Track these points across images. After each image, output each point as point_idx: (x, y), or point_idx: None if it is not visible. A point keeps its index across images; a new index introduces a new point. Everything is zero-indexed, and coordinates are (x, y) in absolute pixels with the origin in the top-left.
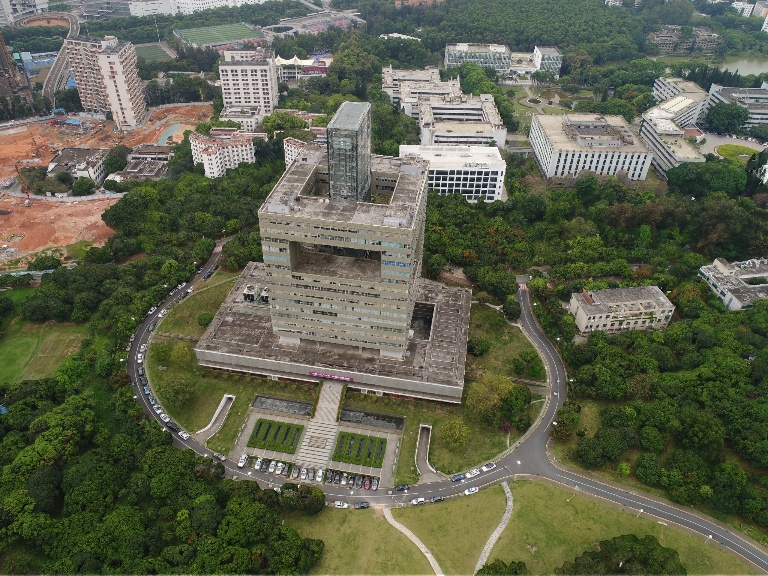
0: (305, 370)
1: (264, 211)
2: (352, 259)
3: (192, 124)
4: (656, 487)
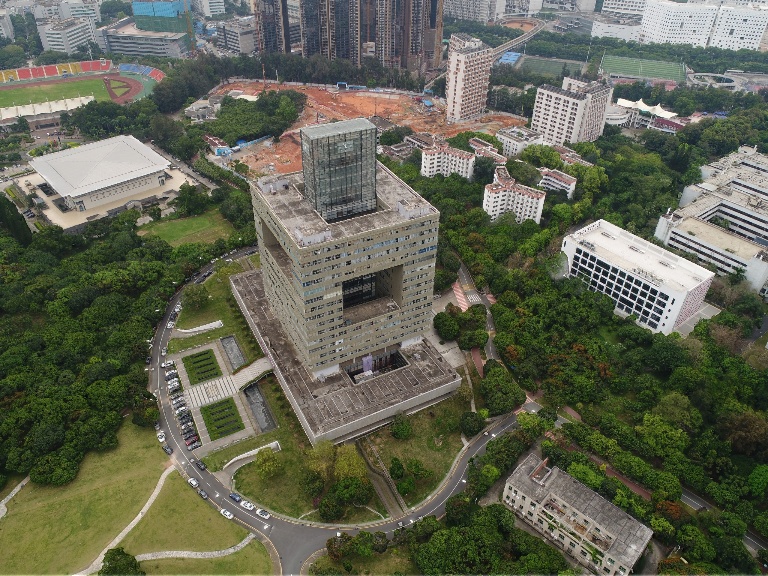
0: None
1: (256, 183)
2: None
3: None
4: None
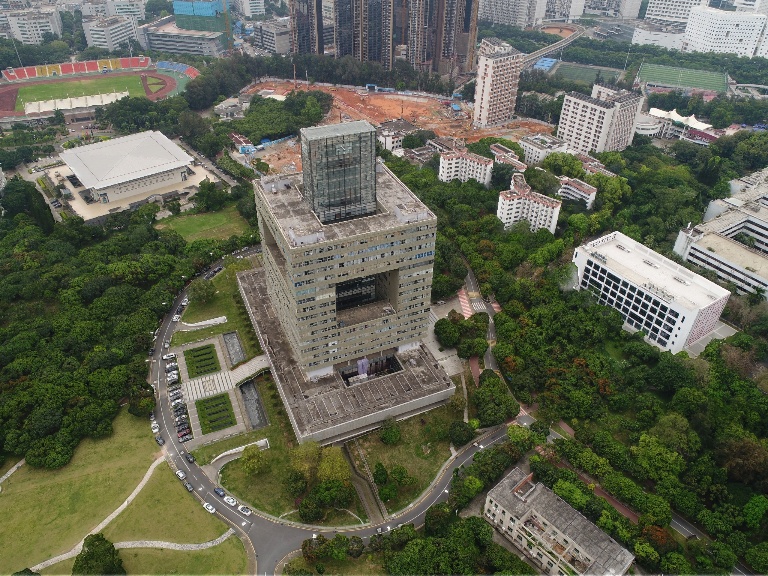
0: None
1: (259, 182)
2: None
3: None
4: None
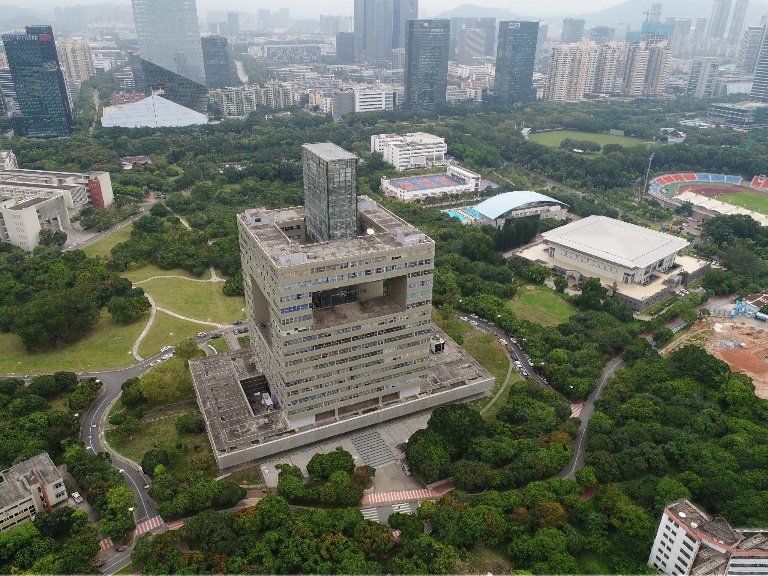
0: None
1: None
2: None
3: None
4: None
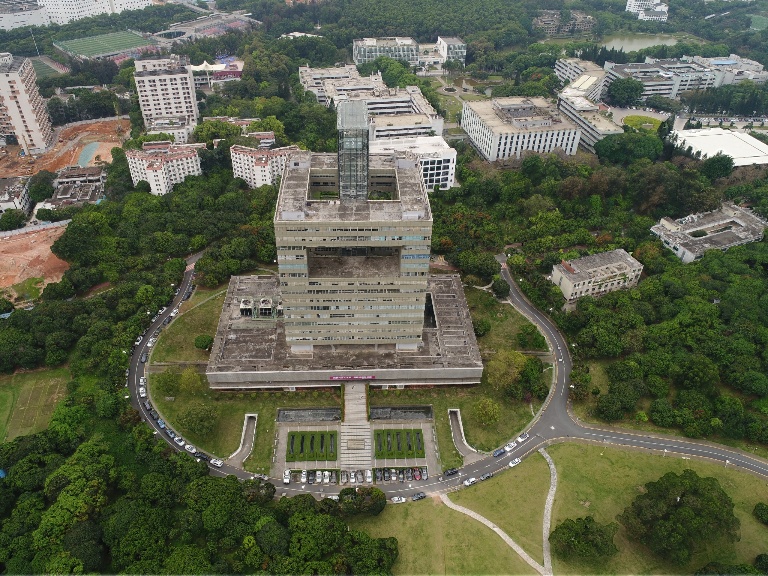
0: (326, 376)
1: (279, 220)
2: (362, 258)
3: (111, 141)
4: (671, 428)
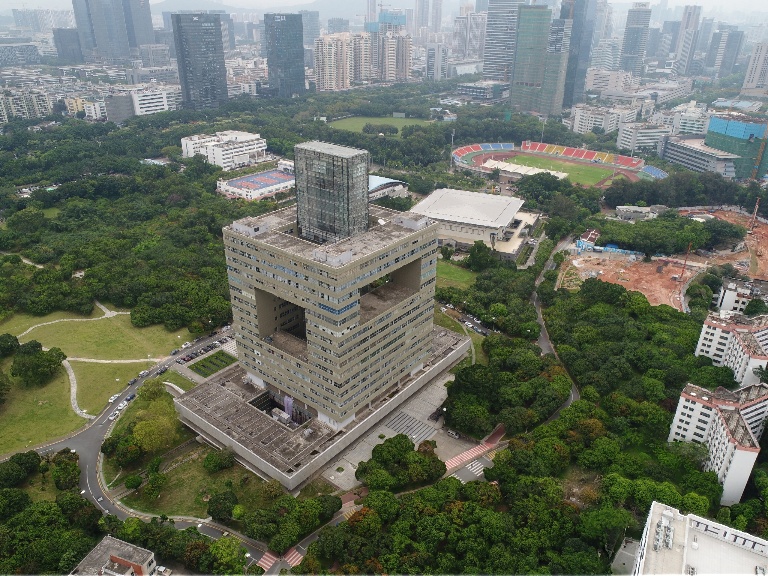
0: None
1: None
2: None
3: None
4: None
